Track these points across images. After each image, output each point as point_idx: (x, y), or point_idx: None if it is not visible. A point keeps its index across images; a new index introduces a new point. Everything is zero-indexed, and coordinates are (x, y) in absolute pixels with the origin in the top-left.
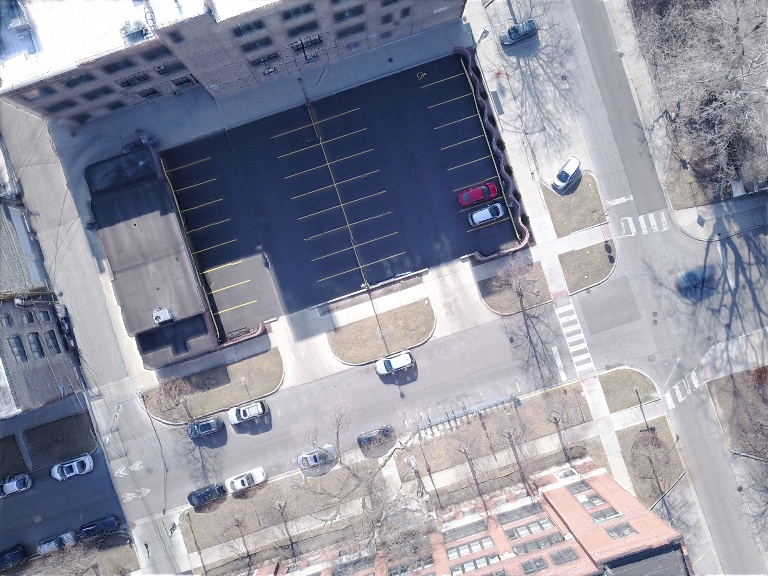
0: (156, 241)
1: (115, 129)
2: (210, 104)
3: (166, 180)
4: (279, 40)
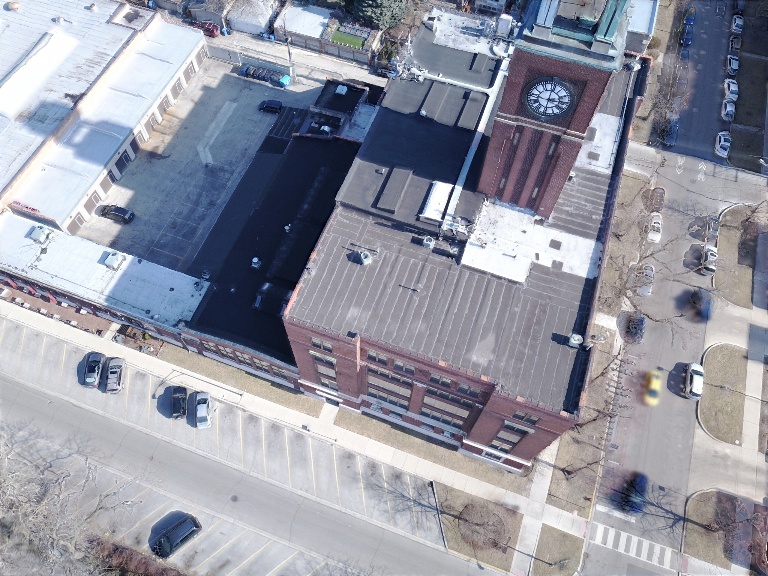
0: None
1: None
2: None
3: None
4: None
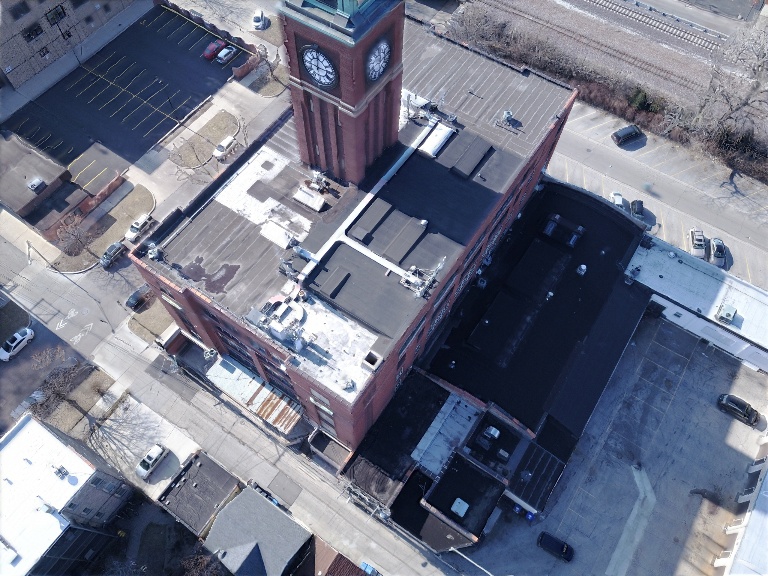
0: (9, 152)
1: None
2: (14, 94)
3: None
4: (35, 7)
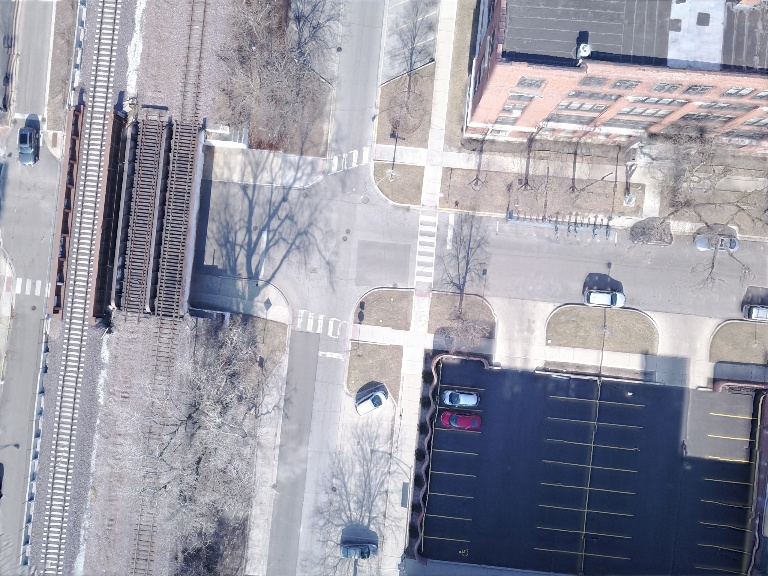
0: None
1: None
2: None
3: (756, 569)
4: None
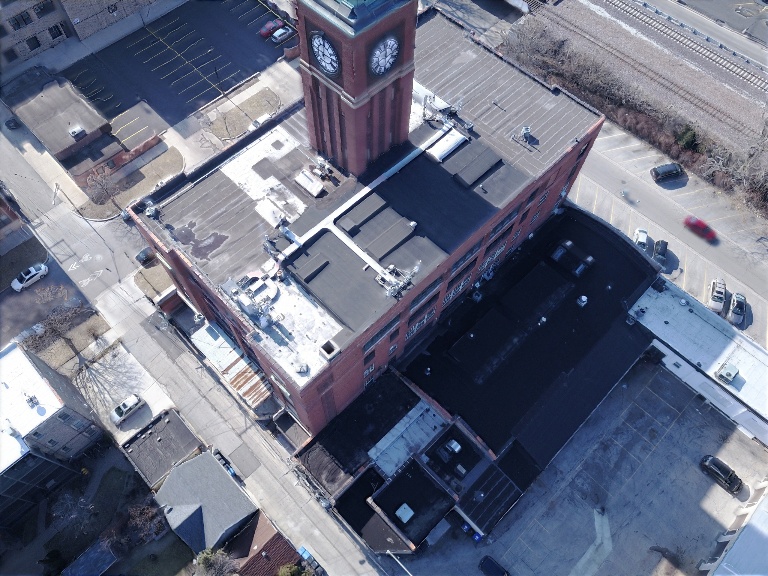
0: (60, 98)
1: (15, 72)
2: (79, 45)
3: None
4: None
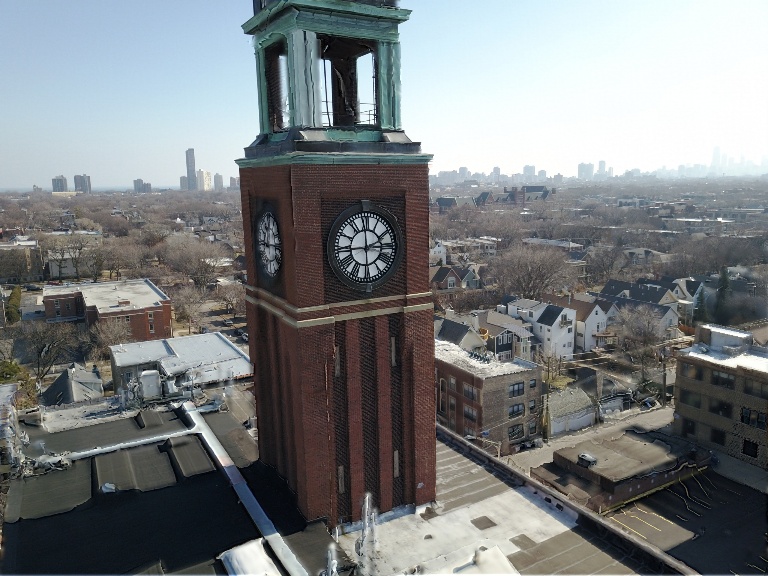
0: (645, 452)
1: None
2: None
3: None
4: None
